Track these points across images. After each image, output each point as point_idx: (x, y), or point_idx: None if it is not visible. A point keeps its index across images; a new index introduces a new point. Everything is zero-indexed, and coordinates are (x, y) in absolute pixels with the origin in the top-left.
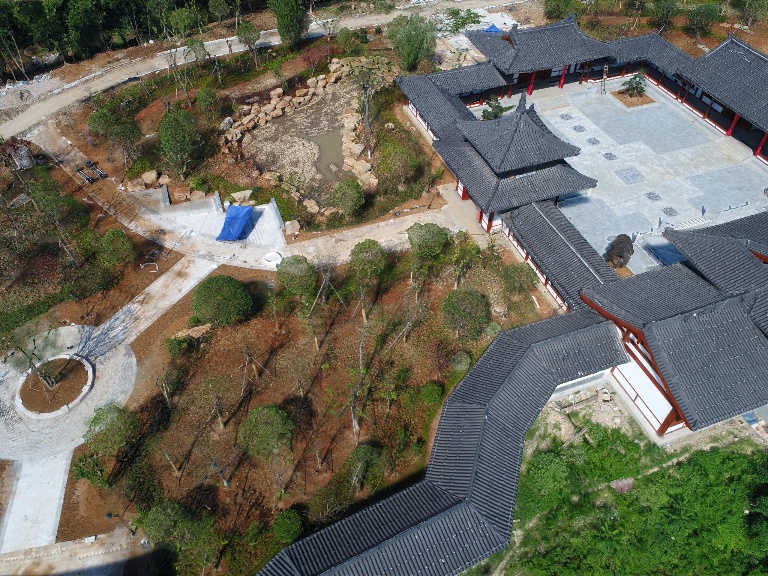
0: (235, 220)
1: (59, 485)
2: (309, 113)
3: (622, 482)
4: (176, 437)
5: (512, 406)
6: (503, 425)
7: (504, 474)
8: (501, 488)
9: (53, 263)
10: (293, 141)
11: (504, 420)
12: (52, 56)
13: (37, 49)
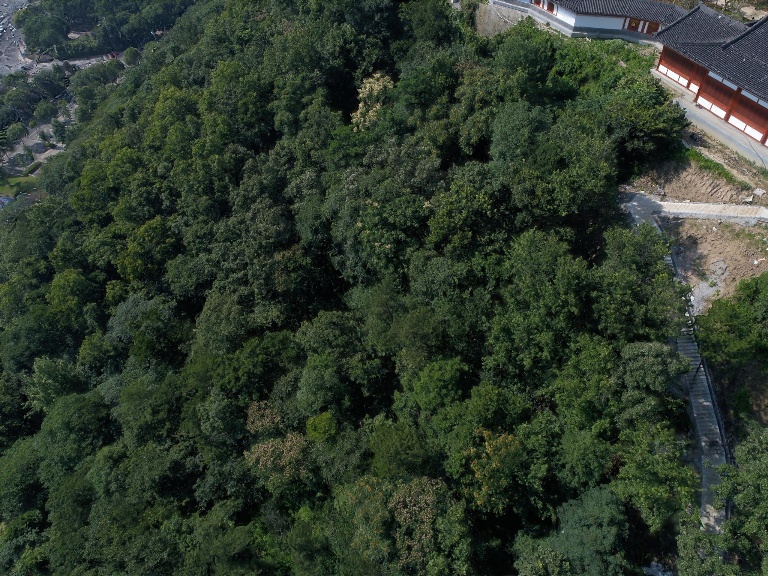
0: None
1: None
2: None
3: (624, 64)
4: None
5: (638, 8)
6: (626, 7)
7: (602, 8)
8: (596, 7)
9: None
10: None
11: (629, 7)
12: None
13: None
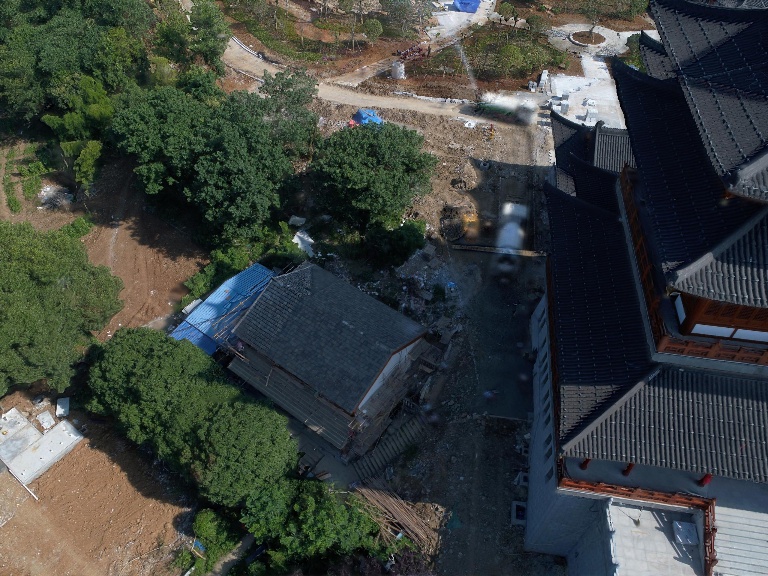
0: (464, 2)
1: (634, 32)
2: (328, 0)
3: None
4: (605, 8)
5: None
6: None
7: None
8: None
9: (511, 44)
10: (364, 4)
11: None
12: (44, 195)
13: (5, 215)
